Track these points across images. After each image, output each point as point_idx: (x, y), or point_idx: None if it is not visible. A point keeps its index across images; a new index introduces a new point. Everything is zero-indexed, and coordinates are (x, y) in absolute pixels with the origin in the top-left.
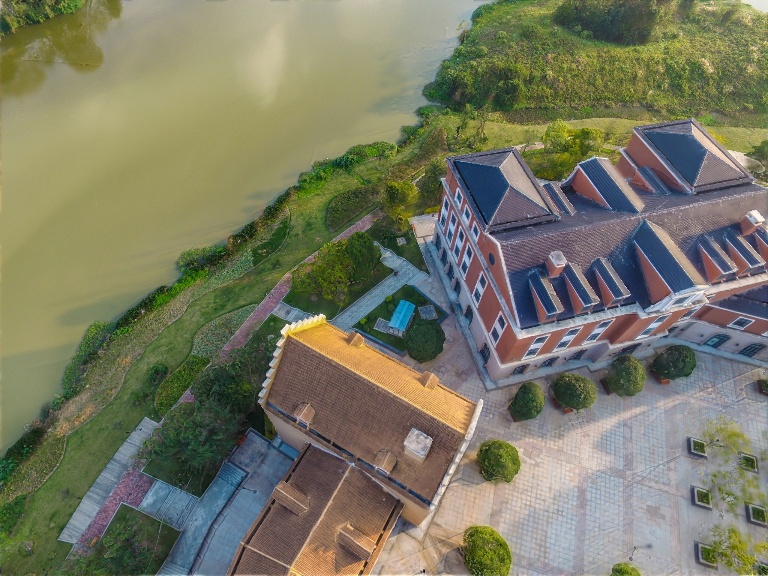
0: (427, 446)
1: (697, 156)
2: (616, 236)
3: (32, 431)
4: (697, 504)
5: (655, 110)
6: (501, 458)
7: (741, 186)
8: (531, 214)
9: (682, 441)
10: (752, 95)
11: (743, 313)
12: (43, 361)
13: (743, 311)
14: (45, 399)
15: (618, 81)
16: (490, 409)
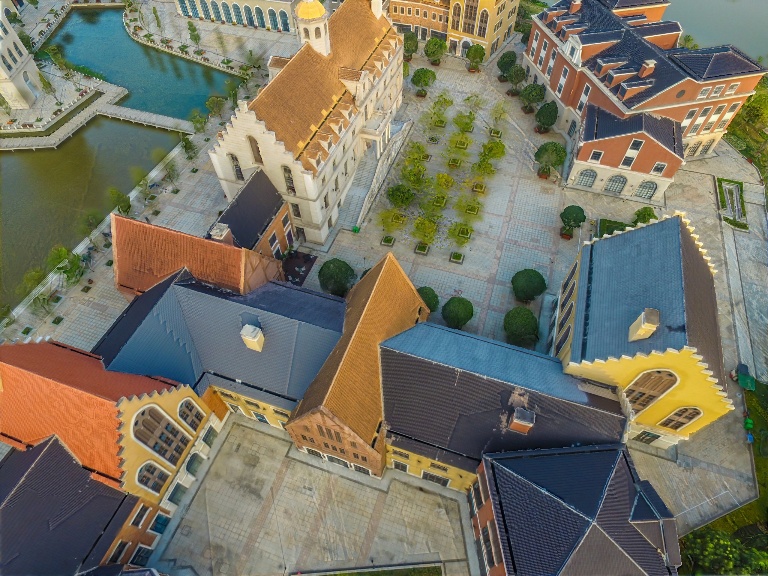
0: None
1: None
2: None
3: None
4: None
5: None
6: None
7: (689, 75)
8: None
9: None
10: None
11: None
12: None
13: None
14: None
15: None
16: None
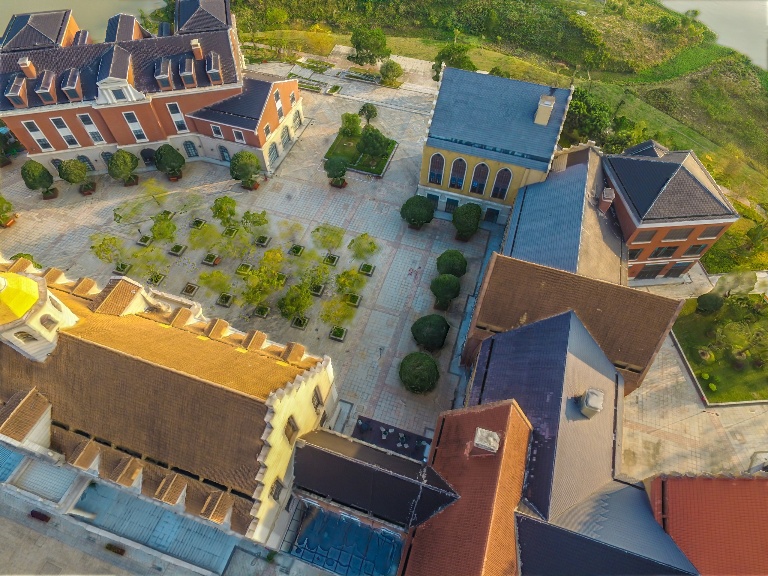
0: None
1: (192, 11)
2: (89, 55)
3: None
4: (138, 243)
5: (336, 25)
6: None
7: None
8: (39, 43)
9: (159, 212)
10: (423, 14)
11: (207, 120)
12: None
13: (207, 118)
14: None
15: (311, 3)
16: (32, 193)
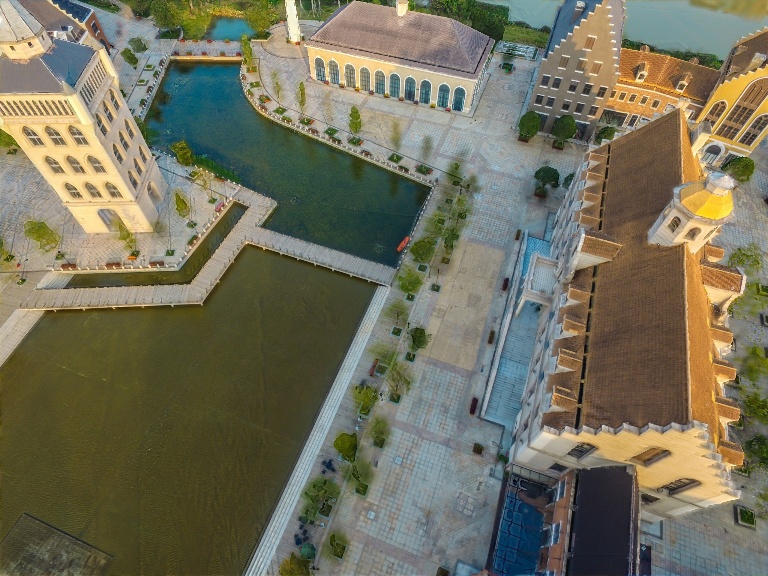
0: (760, 58)
1: None
2: None
3: (653, 47)
4: (759, 284)
5: None
6: (745, 158)
7: None
8: None
9: None
10: None
11: None
12: (685, 45)
13: None
14: (667, 49)
15: None
16: (766, 190)
